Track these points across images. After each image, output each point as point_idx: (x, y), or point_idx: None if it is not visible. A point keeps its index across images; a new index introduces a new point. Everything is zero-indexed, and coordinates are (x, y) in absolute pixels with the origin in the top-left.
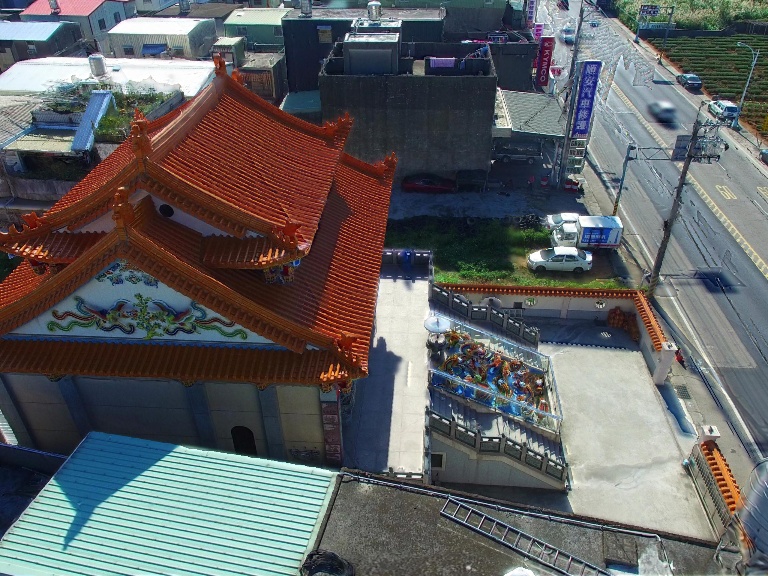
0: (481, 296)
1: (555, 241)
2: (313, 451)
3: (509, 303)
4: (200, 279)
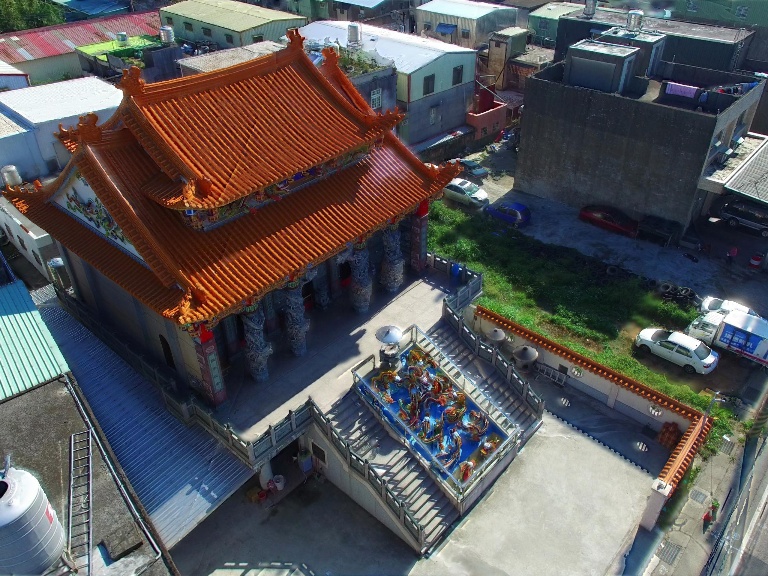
0: (524, 342)
1: (689, 326)
2: (201, 382)
3: (554, 363)
4: (120, 199)
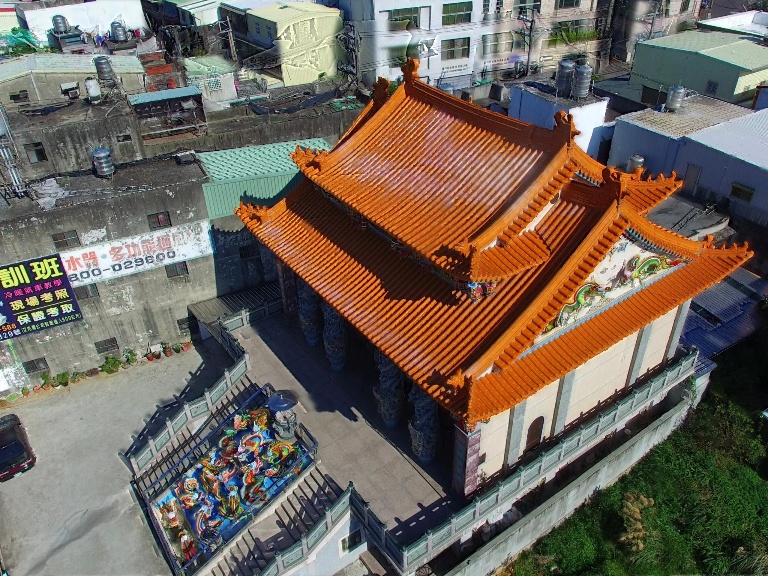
0: None
1: None
2: None
3: None
4: None
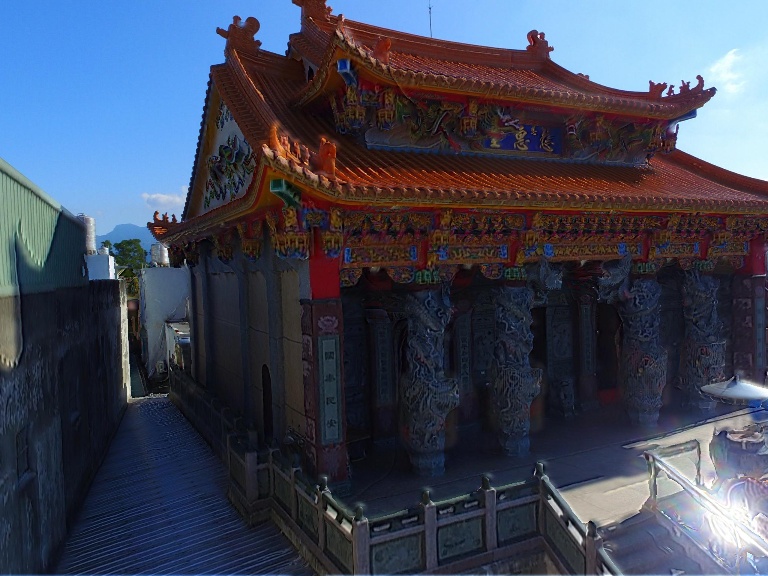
0: None
1: None
2: (303, 437)
3: None
4: (251, 94)
